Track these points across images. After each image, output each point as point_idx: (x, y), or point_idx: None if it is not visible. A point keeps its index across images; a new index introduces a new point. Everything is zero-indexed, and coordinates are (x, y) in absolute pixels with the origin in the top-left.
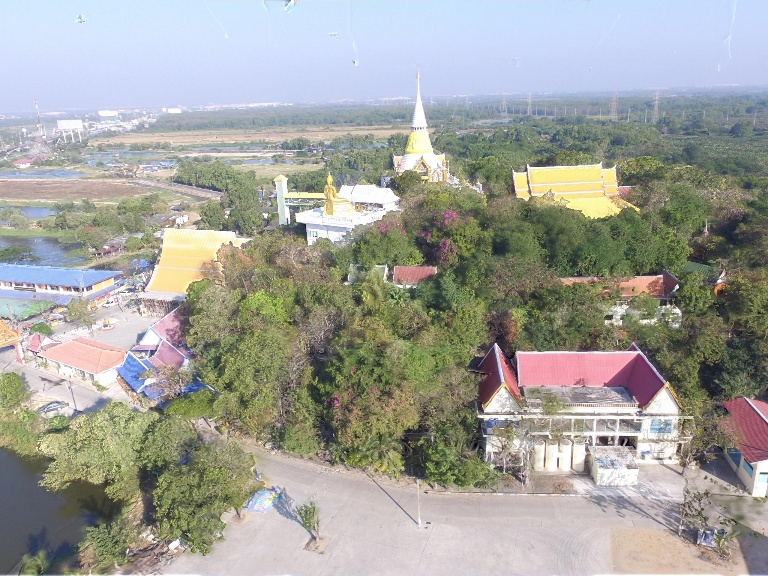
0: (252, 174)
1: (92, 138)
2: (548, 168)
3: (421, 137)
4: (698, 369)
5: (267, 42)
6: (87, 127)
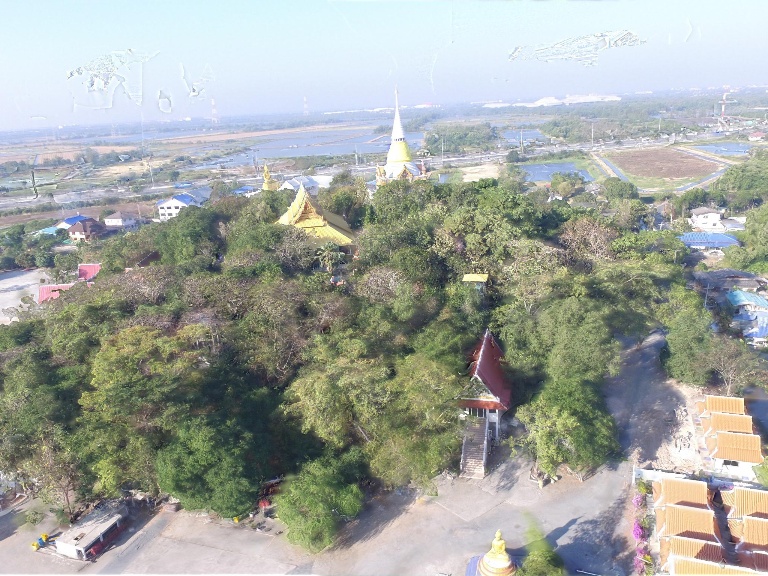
0: None
1: None
2: None
3: None
4: None
5: (91, 104)
6: None
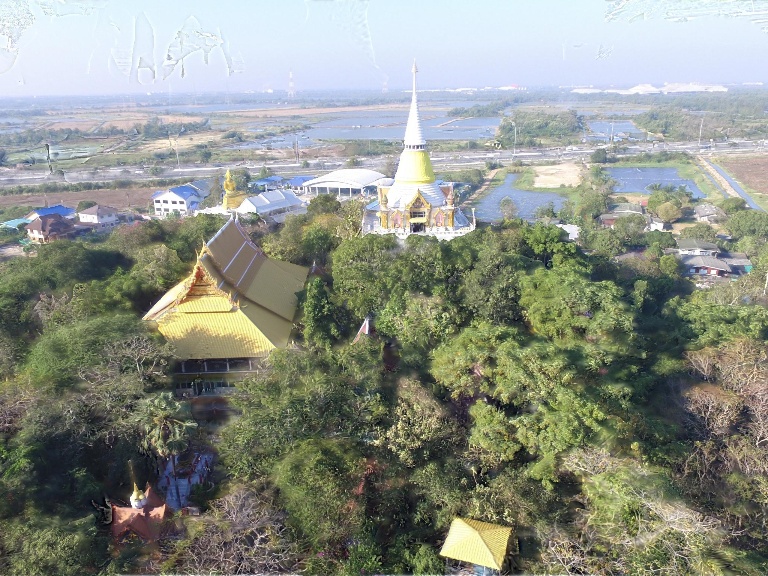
0: None
1: None
2: None
3: None
4: None
5: None
6: None
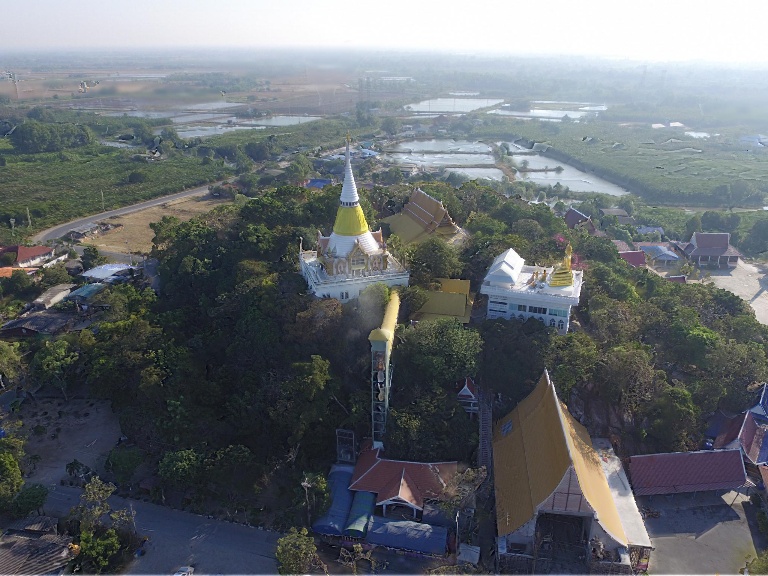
0: None
1: None
2: None
3: None
4: None
5: None
6: None
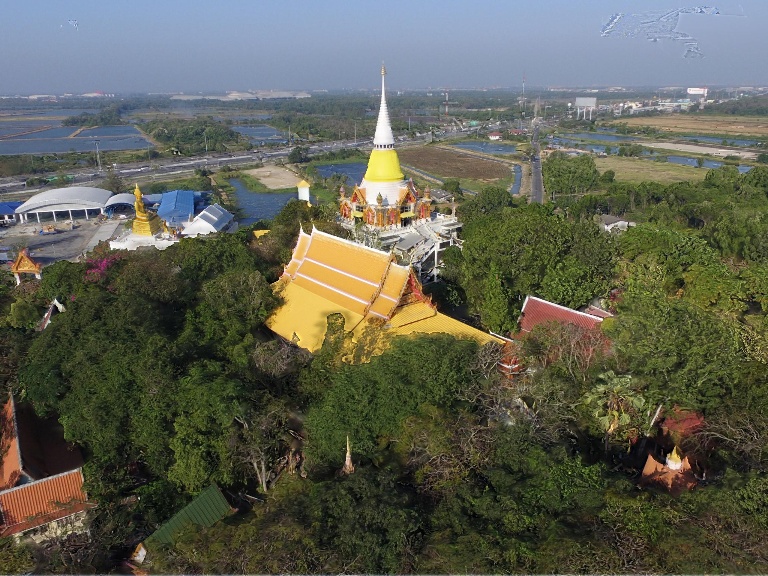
0: (609, 175)
1: (600, 117)
2: (332, 237)
3: (374, 158)
4: None
5: None
6: (599, 105)
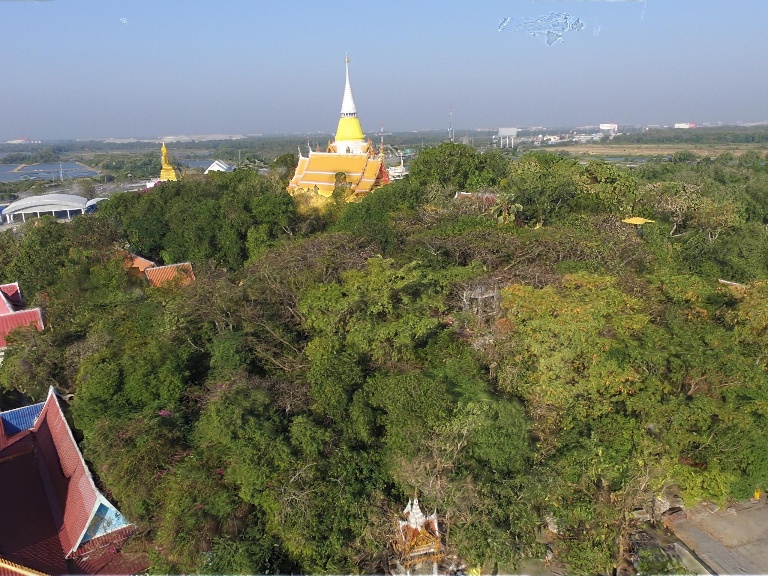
0: None
1: (521, 144)
2: (325, 154)
3: (342, 123)
4: (7, 342)
5: None
6: (519, 134)
